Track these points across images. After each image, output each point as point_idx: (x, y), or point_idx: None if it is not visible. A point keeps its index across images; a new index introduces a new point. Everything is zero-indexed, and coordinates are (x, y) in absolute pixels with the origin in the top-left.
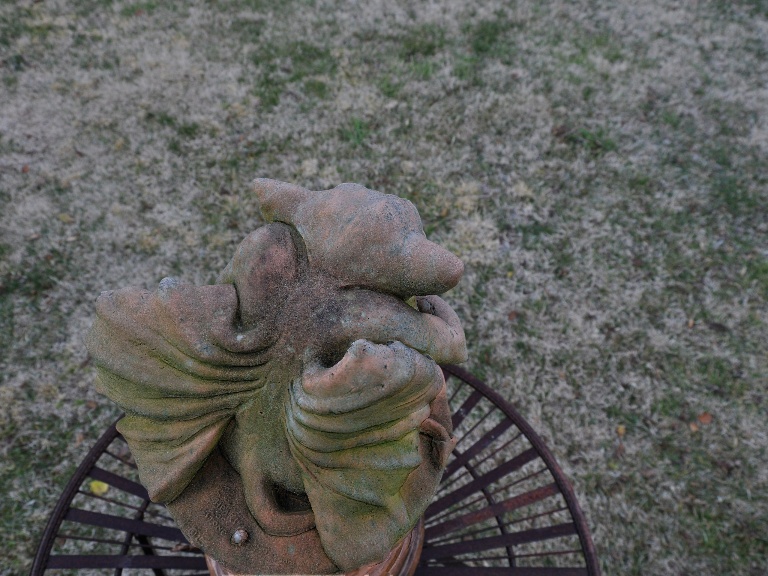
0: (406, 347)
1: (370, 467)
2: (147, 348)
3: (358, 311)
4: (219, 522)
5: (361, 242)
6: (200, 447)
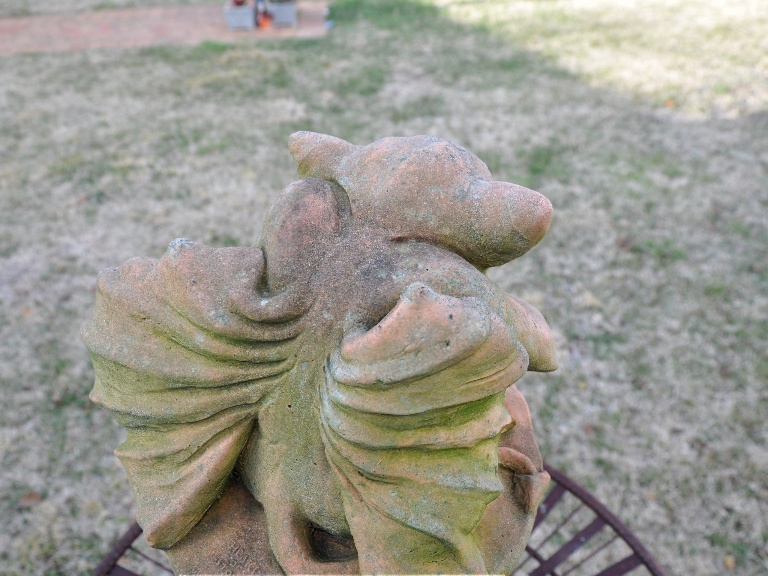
0: (477, 298)
1: (433, 481)
2: (152, 323)
3: (413, 263)
4: (234, 571)
5: (416, 184)
6: (212, 460)
